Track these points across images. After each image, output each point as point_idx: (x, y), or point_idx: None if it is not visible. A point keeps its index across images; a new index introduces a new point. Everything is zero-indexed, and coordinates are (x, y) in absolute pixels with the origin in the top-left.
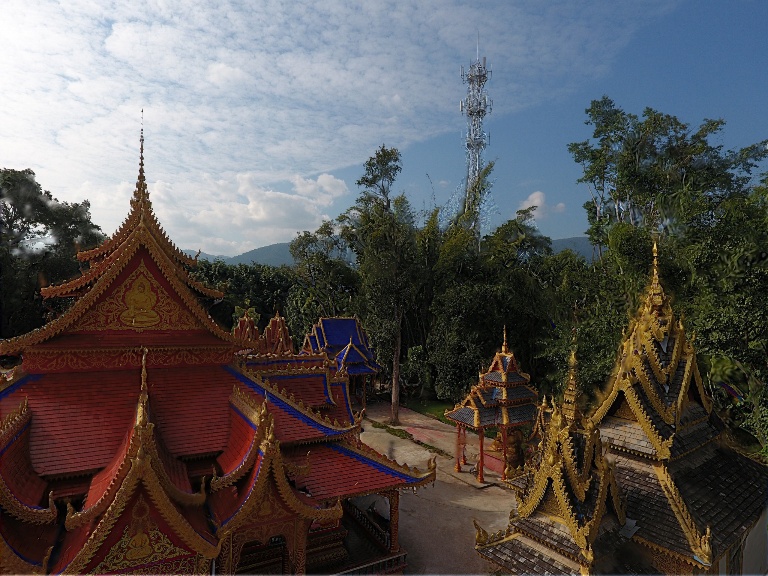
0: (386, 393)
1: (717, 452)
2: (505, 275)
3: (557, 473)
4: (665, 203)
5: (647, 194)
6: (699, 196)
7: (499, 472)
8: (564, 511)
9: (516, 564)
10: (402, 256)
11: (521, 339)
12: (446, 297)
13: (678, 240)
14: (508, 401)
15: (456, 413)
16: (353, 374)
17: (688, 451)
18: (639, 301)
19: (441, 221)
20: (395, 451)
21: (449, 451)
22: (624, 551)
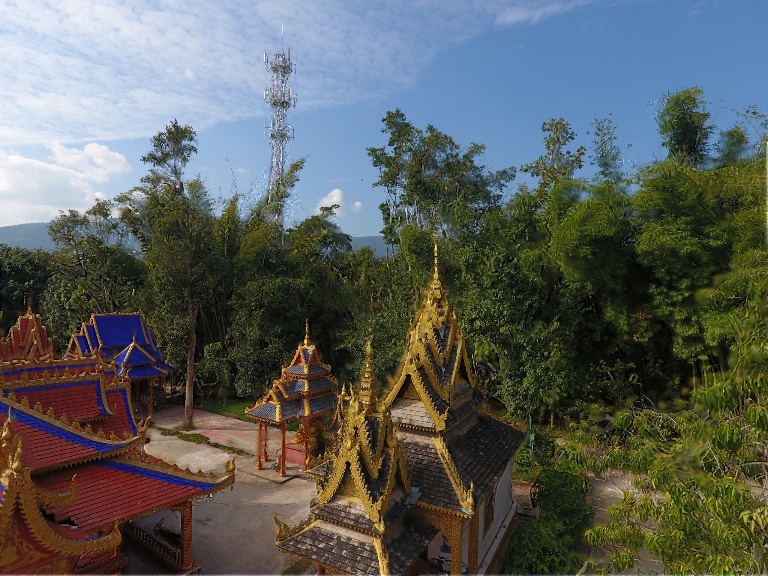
0: (178, 396)
1: (478, 419)
2: (308, 269)
3: (354, 456)
4: (444, 210)
5: (430, 201)
6: (468, 207)
7: (301, 463)
8: (360, 491)
9: (316, 551)
10: (198, 246)
11: (323, 331)
12: (247, 290)
13: (453, 243)
14: (310, 393)
15: (257, 410)
16: (137, 378)
17: (458, 421)
18: (423, 295)
19: (242, 211)
20: (188, 458)
21: (250, 450)
22: (410, 516)
